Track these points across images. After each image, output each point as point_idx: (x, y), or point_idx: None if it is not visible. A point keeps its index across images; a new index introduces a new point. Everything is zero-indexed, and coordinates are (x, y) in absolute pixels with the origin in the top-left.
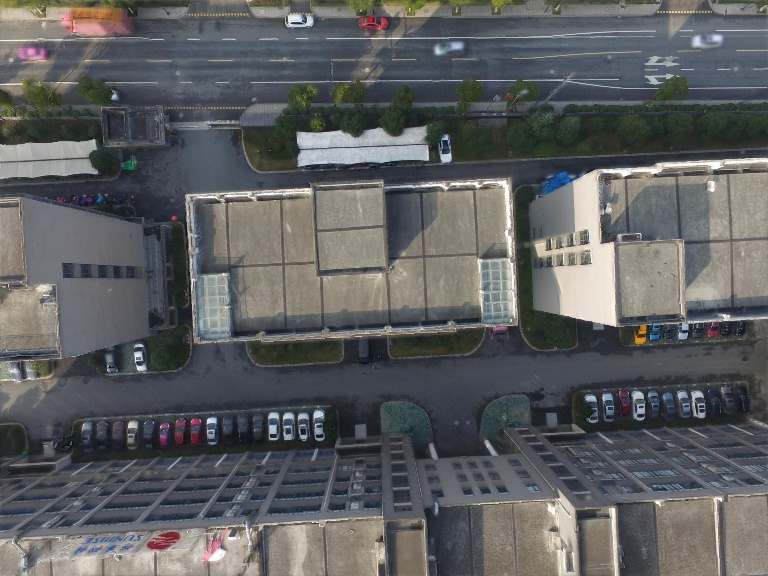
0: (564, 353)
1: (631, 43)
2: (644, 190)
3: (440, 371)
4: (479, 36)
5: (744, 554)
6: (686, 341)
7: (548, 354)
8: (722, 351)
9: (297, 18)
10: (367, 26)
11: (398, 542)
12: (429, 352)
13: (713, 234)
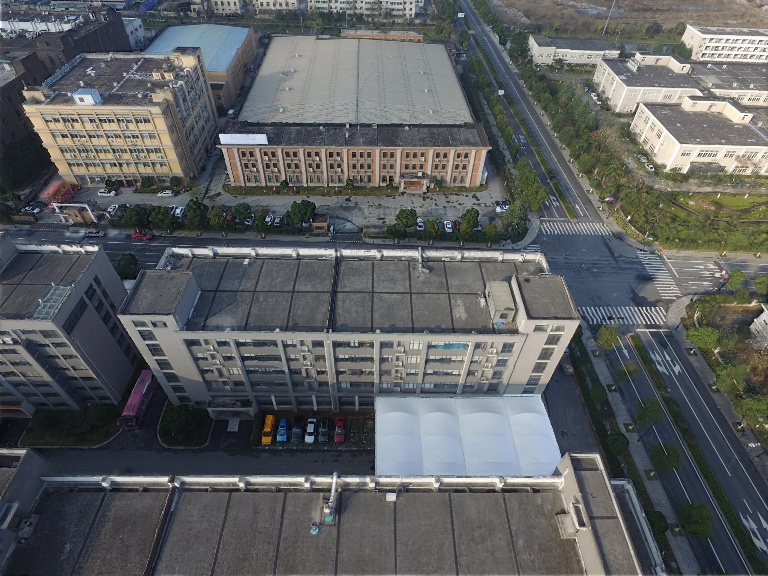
0: (191, 451)
1: None
2: (203, 264)
3: (59, 462)
4: None
5: (182, 560)
6: (315, 447)
7: (175, 451)
8: (350, 459)
9: (93, 231)
10: (136, 237)
11: None
12: (59, 443)
13: (242, 287)
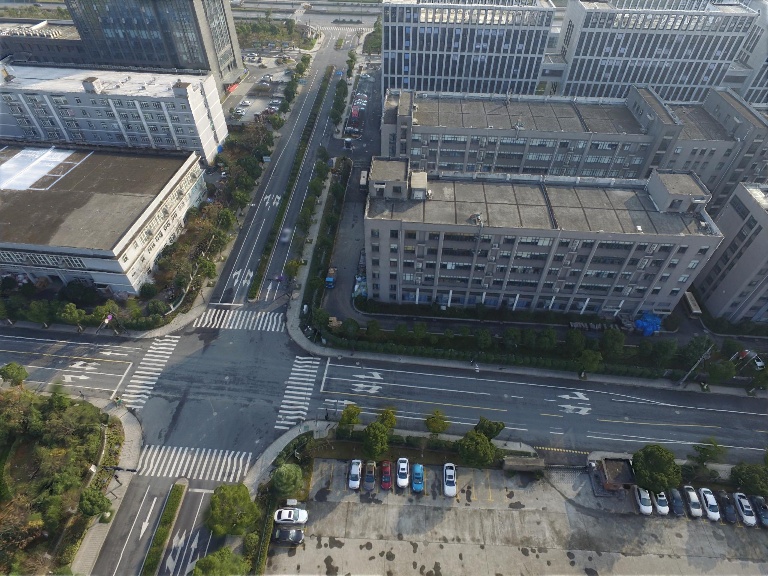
0: None
1: (609, 428)
2: None
3: None
4: (763, 452)
5: None
6: None
7: None
8: None
9: None
10: None
11: (762, 125)
12: None
13: None
